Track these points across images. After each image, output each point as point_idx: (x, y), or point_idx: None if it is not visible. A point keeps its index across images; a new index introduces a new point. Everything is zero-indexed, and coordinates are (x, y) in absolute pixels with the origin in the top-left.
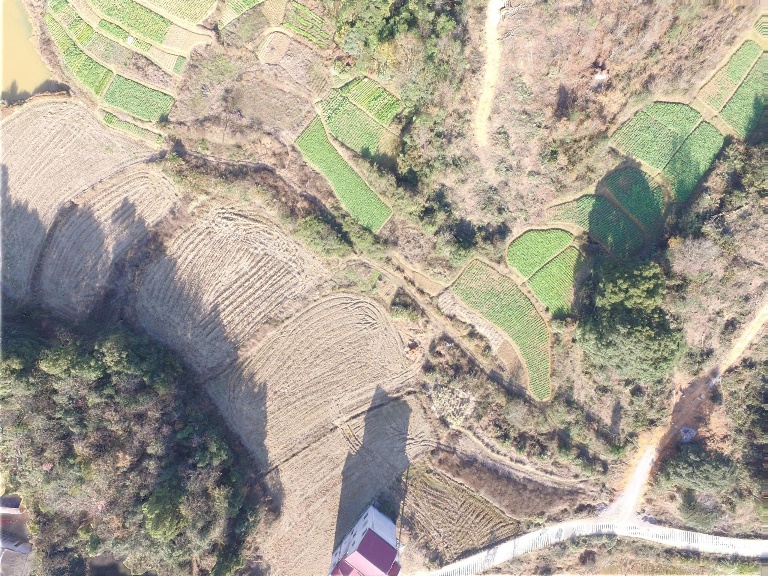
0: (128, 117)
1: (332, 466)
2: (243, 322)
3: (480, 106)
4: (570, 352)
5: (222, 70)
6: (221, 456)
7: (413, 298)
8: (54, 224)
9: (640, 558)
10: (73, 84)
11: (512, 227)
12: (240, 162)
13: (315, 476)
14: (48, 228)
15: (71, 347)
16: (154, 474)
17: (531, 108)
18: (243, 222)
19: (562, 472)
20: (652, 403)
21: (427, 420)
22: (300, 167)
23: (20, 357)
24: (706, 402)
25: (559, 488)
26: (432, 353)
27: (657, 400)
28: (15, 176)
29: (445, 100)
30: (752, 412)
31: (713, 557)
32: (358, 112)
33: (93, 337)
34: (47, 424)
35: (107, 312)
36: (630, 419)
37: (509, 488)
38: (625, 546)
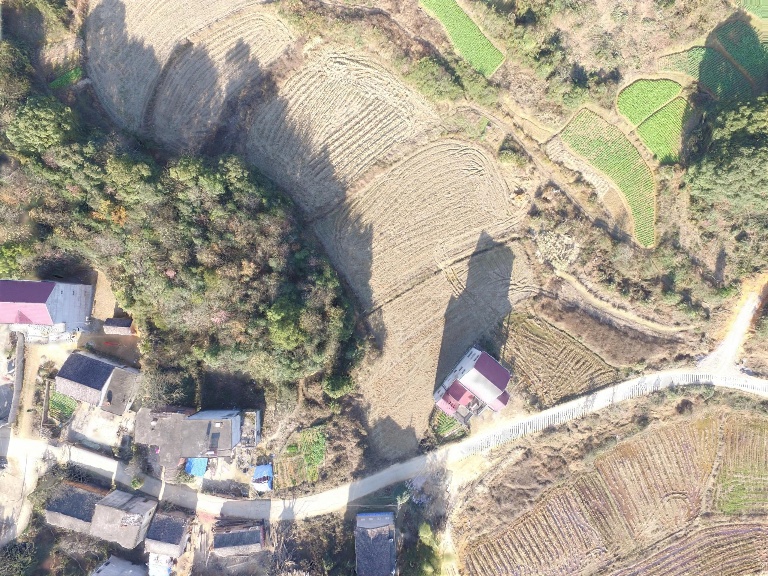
0: None
1: (435, 308)
2: (352, 163)
3: None
4: (677, 199)
5: None
6: (334, 282)
7: (521, 145)
8: (169, 60)
9: (736, 411)
10: None
11: (624, 74)
12: (356, 6)
13: (418, 318)
14: (163, 64)
15: None
16: (277, 284)
17: None
18: (355, 67)
19: (664, 319)
20: (758, 249)
21: (530, 266)
22: (416, 11)
23: (148, 165)
24: None
25: (659, 337)
26: (539, 198)
27: (763, 245)
28: (132, 13)
29: None
30: None
31: None
32: None
33: (214, 158)
34: (172, 231)
35: (218, 148)
36: (734, 266)
37: (611, 333)
38: (722, 397)
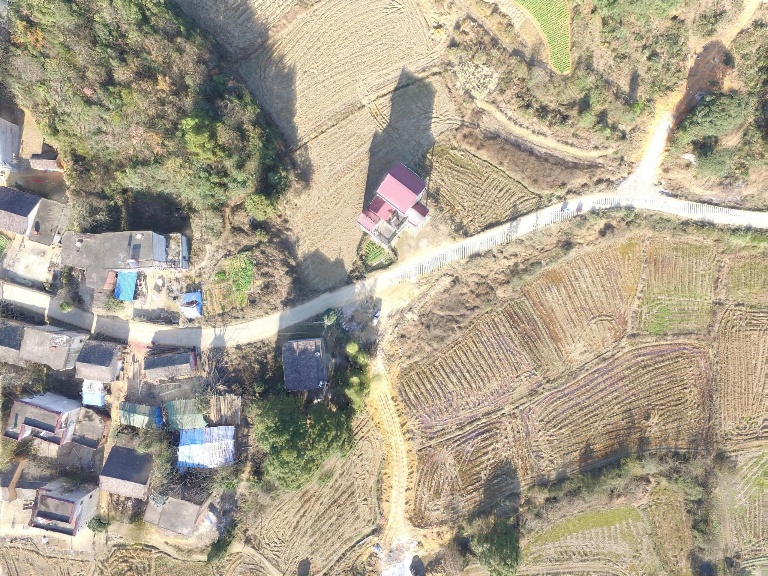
0: None
1: (360, 143)
2: (274, 5)
3: None
4: (589, 24)
5: None
6: (255, 108)
7: None
8: None
9: (657, 233)
10: None
11: None
12: None
13: (343, 153)
14: None
15: None
16: (193, 98)
17: None
18: None
19: (582, 143)
20: (668, 66)
21: (452, 99)
22: None
23: None
24: (719, 66)
25: (579, 163)
26: (457, 29)
27: (673, 62)
28: None
29: None
30: (763, 72)
31: (727, 227)
32: None
33: None
34: (89, 51)
35: None
36: (647, 86)
37: (531, 157)
38: (643, 220)
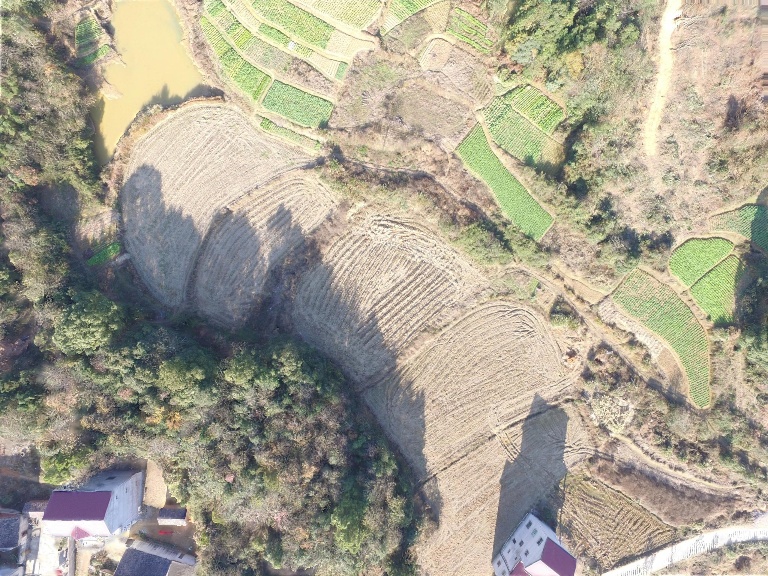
0: (287, 123)
1: (490, 474)
2: (401, 330)
3: (650, 115)
4: (732, 360)
5: (383, 76)
6: (392, 466)
7: (572, 306)
8: (209, 231)
9: None
10: (228, 89)
11: (676, 236)
12: (399, 169)
13: (473, 484)
14: (203, 235)
15: (249, 357)
16: (339, 485)
17: (701, 118)
18: (399, 229)
19: (721, 479)
20: None
21: (585, 428)
22: (461, 175)
23: (201, 367)
24: None
25: (716, 495)
26: (593, 361)
27: None
28: (168, 182)
29: (617, 109)
30: None
31: None
32: (521, 120)
33: (264, 346)
34: (229, 435)
35: (264, 320)
36: None
37: (669, 495)
38: None
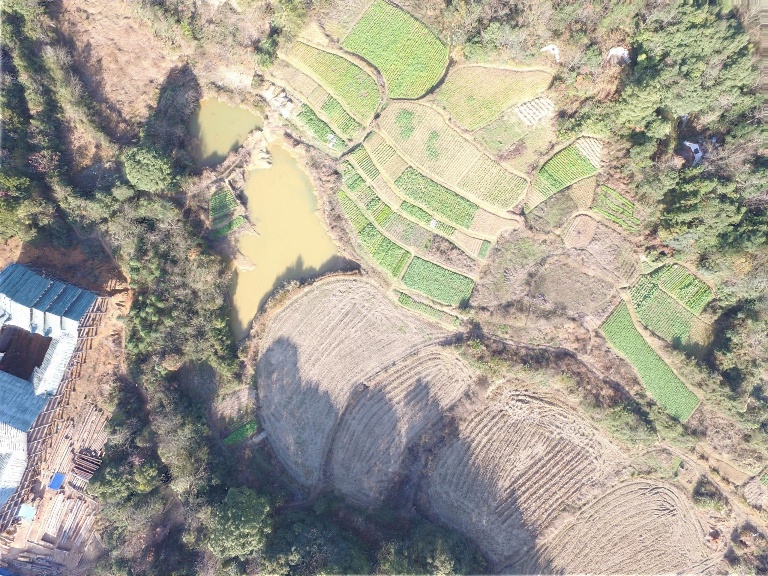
0: (426, 300)
1: None
2: (540, 509)
3: None
4: None
5: (525, 253)
6: None
7: (716, 486)
8: (346, 407)
9: None
10: (365, 263)
11: None
12: (540, 346)
13: None
14: (340, 412)
15: (404, 560)
16: None
17: None
18: (538, 405)
19: None
20: None
21: None
22: (605, 354)
23: (358, 575)
24: None
25: None
26: (739, 545)
27: None
28: (304, 357)
29: None
30: None
31: None
32: (668, 300)
33: (414, 542)
34: None
35: (401, 499)
36: None
37: None
38: None
